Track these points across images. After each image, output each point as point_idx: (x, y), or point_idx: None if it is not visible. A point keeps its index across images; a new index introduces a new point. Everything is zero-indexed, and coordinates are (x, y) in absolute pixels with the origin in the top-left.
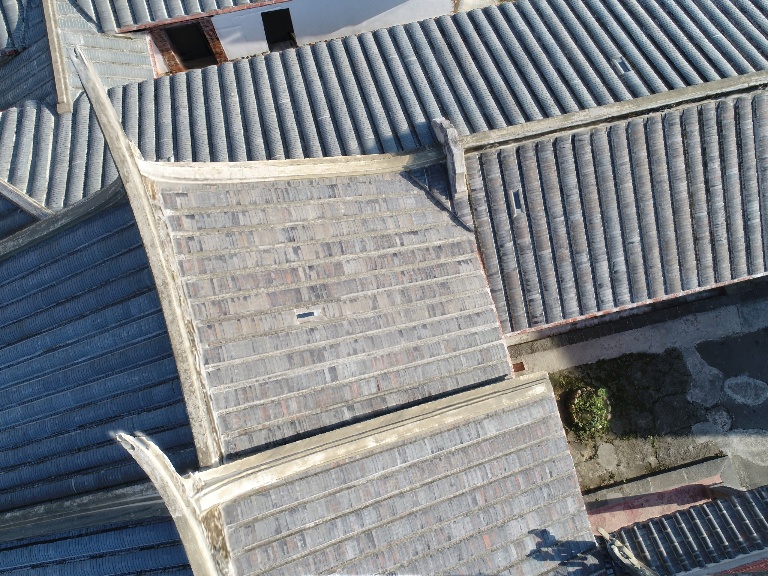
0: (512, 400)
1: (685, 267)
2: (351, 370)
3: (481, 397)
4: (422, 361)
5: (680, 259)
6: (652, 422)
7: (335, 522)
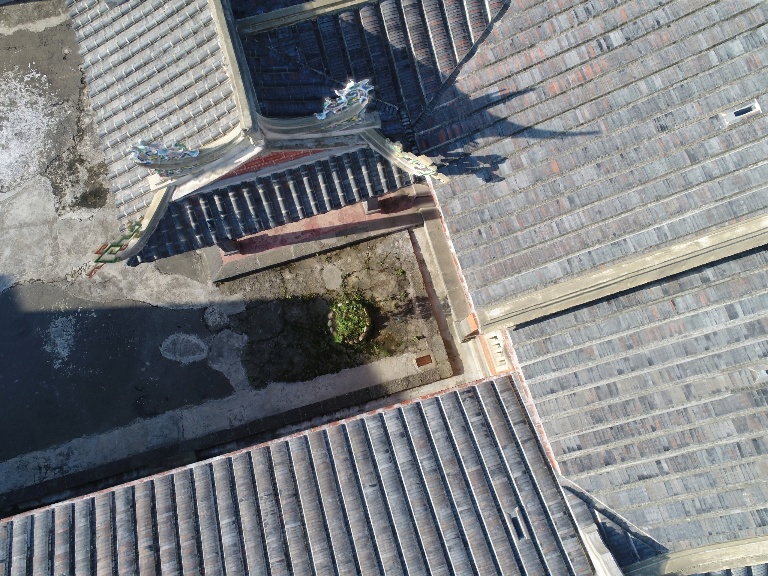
0: (530, 299)
1: (307, 462)
2: (710, 318)
3: (565, 300)
4: (620, 336)
5: (312, 471)
6: (286, 312)
7: (736, 167)
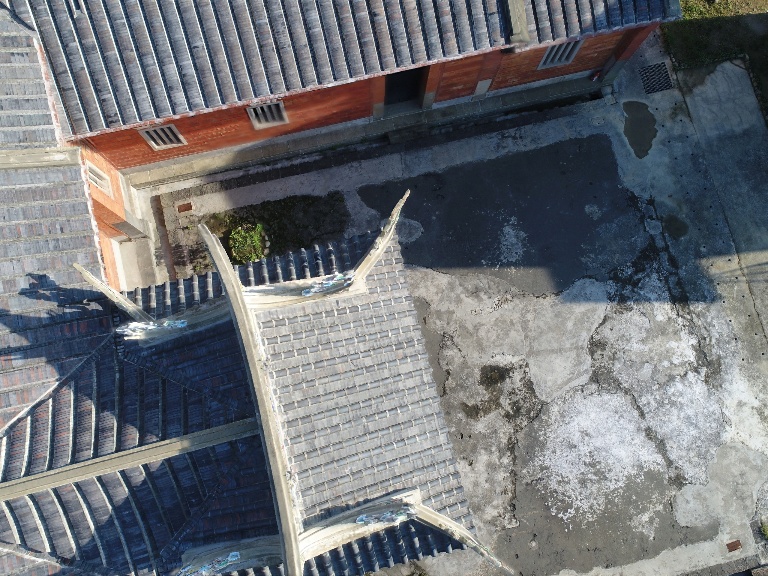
0: (22, 161)
1: (253, 73)
2: None
3: None
4: None
5: (249, 66)
6: None
7: None
